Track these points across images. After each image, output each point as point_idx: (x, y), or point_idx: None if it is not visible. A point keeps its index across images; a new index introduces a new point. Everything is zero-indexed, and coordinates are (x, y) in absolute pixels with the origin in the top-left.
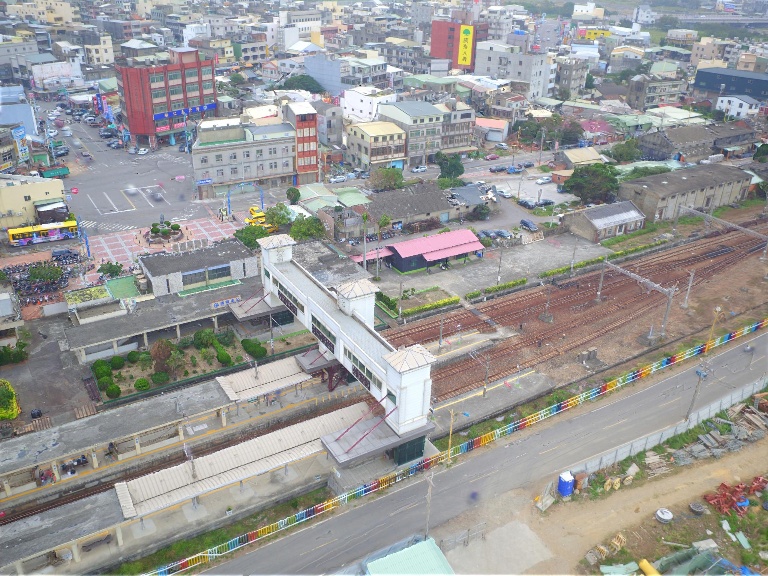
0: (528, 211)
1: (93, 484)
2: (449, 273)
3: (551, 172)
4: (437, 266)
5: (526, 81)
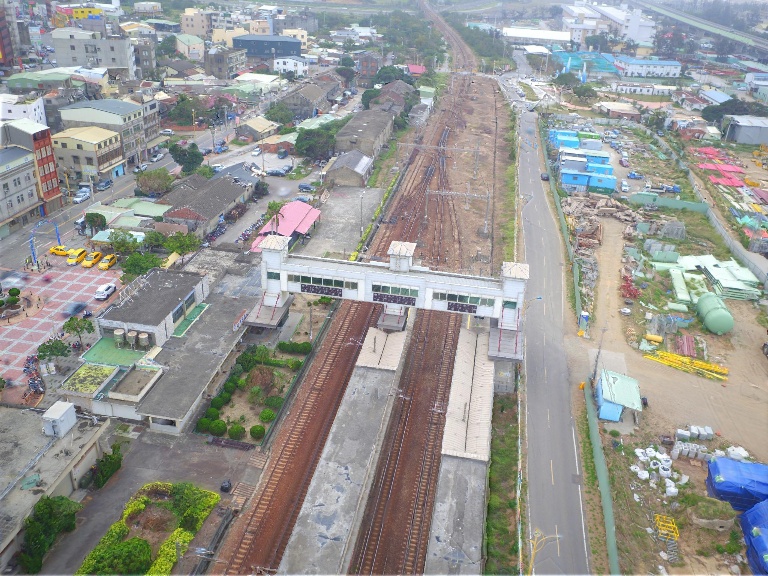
0: (285, 178)
1: (370, 489)
2: (316, 240)
3: (257, 143)
4: None
5: (125, 66)
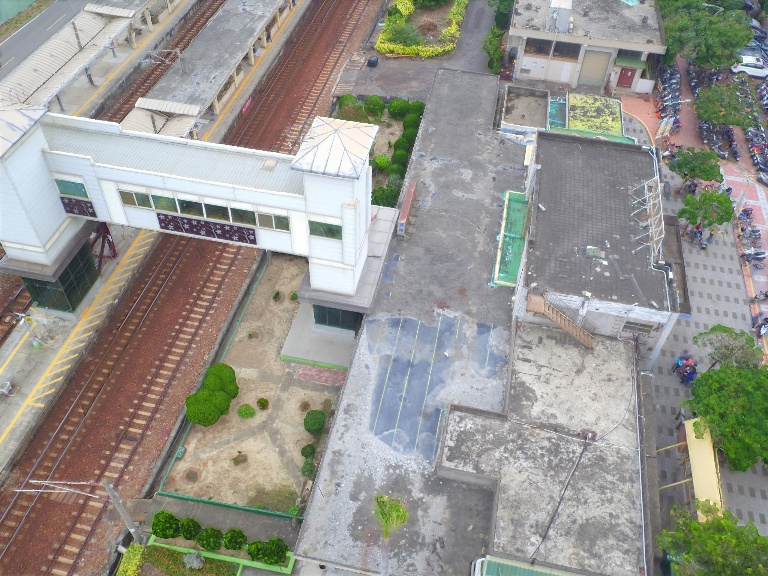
0: None
1: None
2: None
3: None
4: None
5: None
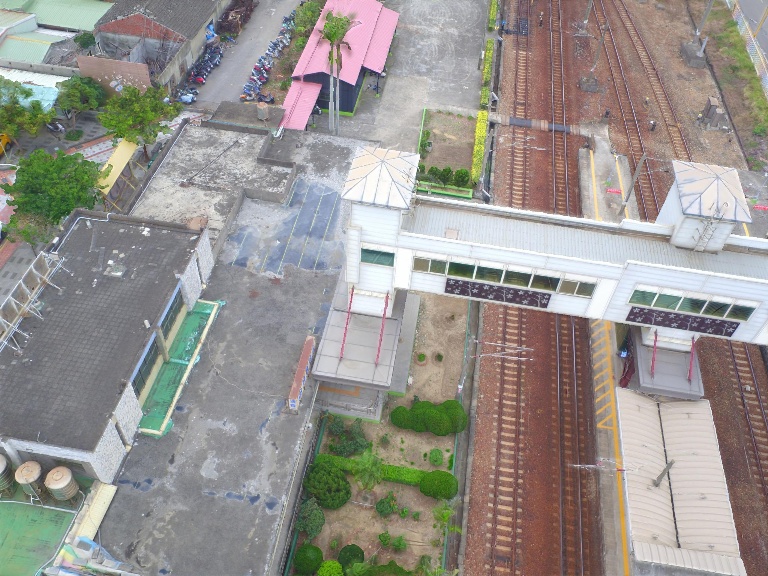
0: None
1: None
2: (398, 79)
3: None
4: (366, 75)
5: None
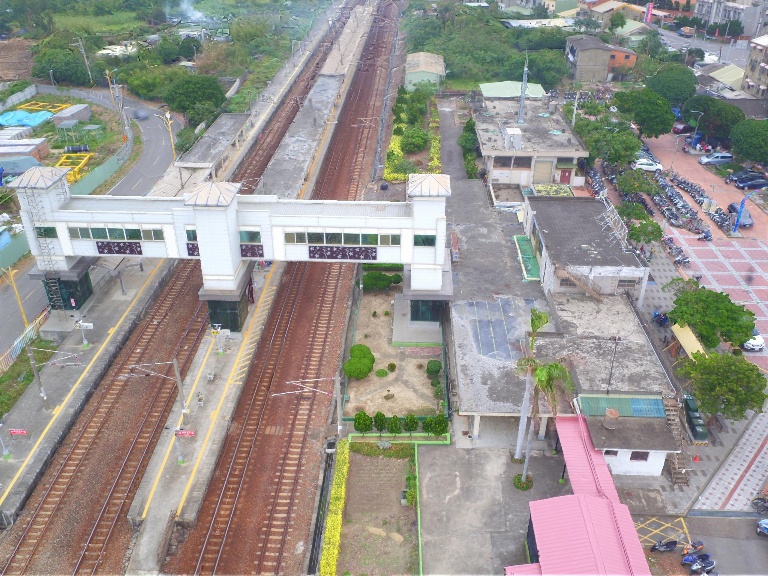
0: None
1: None
2: None
3: None
4: None
5: None
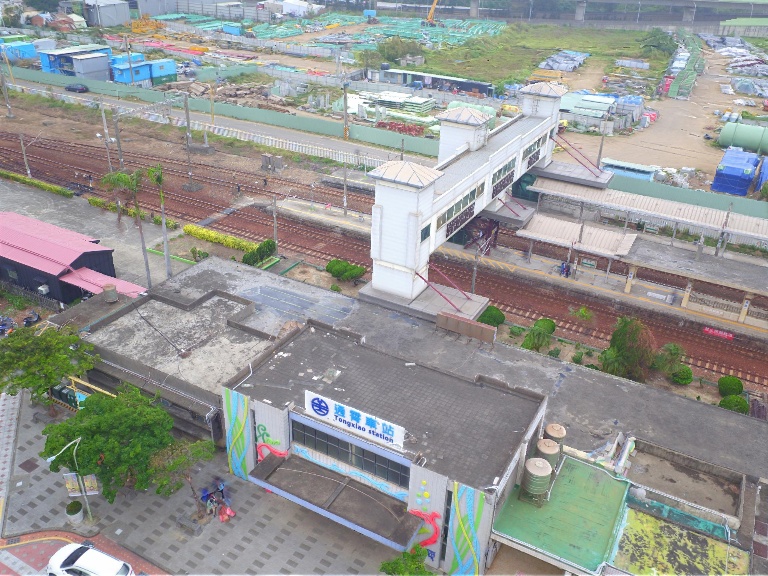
0: None
1: None
2: None
3: None
4: None
5: None
